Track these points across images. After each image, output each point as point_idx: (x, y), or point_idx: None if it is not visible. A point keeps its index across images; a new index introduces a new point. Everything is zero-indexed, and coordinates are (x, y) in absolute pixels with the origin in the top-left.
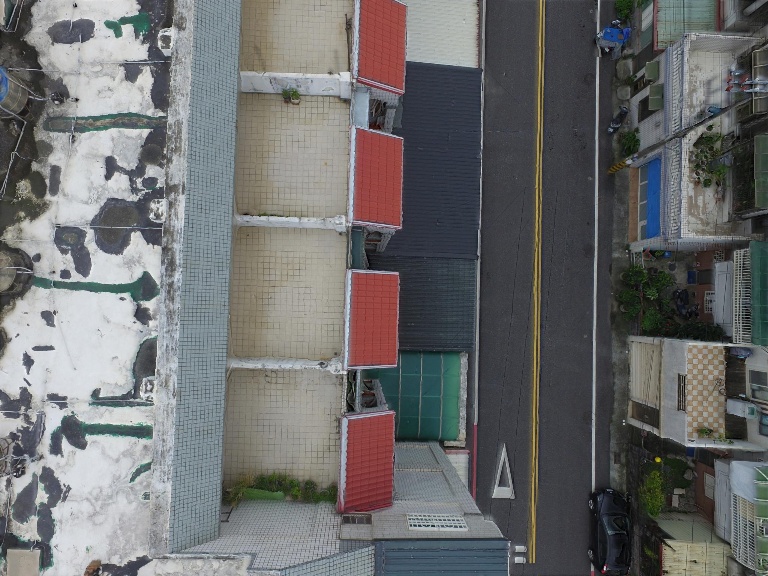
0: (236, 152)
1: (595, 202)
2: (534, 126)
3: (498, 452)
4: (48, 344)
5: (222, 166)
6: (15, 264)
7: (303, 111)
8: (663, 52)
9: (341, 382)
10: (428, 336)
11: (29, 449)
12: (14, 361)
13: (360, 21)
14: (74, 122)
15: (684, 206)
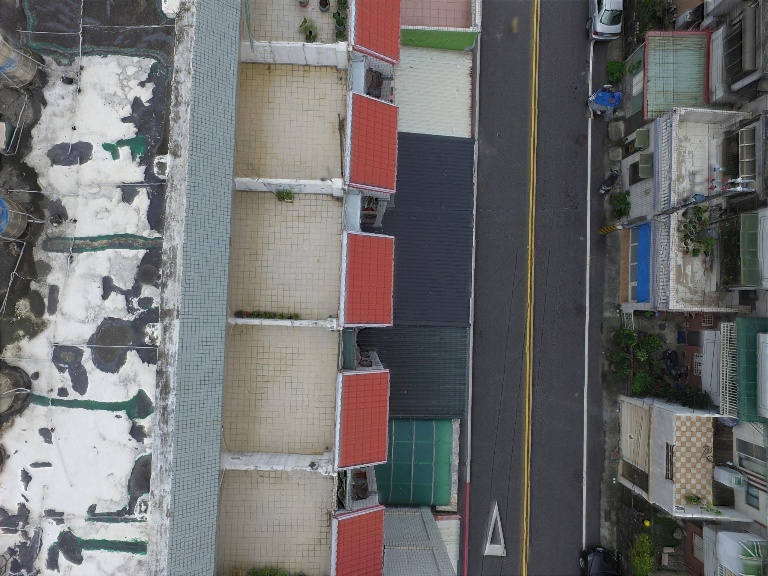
0: (230, 265)
1: (587, 262)
2: (527, 187)
3: (490, 510)
4: (45, 461)
5: (216, 285)
6: (14, 386)
7: (296, 209)
8: (653, 121)
9: (332, 476)
10: (420, 404)
11: (26, 564)
12: (12, 477)
13: (352, 128)
14: (72, 243)
15: (672, 278)
